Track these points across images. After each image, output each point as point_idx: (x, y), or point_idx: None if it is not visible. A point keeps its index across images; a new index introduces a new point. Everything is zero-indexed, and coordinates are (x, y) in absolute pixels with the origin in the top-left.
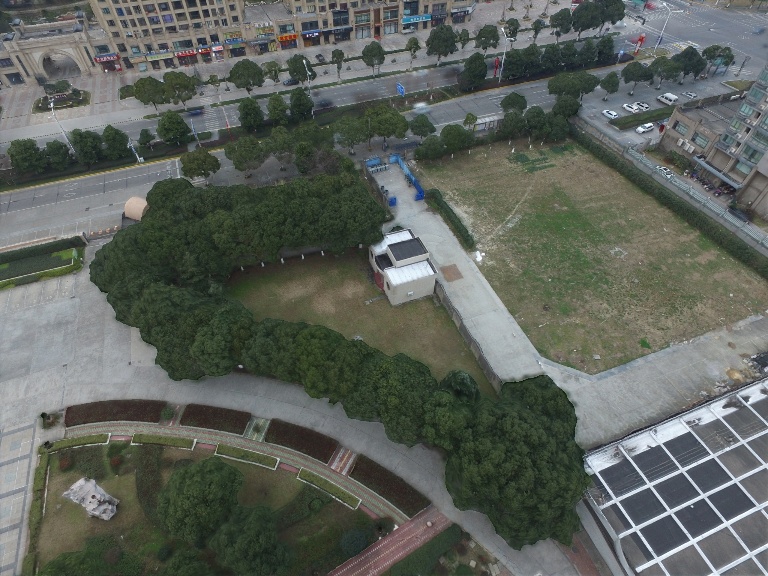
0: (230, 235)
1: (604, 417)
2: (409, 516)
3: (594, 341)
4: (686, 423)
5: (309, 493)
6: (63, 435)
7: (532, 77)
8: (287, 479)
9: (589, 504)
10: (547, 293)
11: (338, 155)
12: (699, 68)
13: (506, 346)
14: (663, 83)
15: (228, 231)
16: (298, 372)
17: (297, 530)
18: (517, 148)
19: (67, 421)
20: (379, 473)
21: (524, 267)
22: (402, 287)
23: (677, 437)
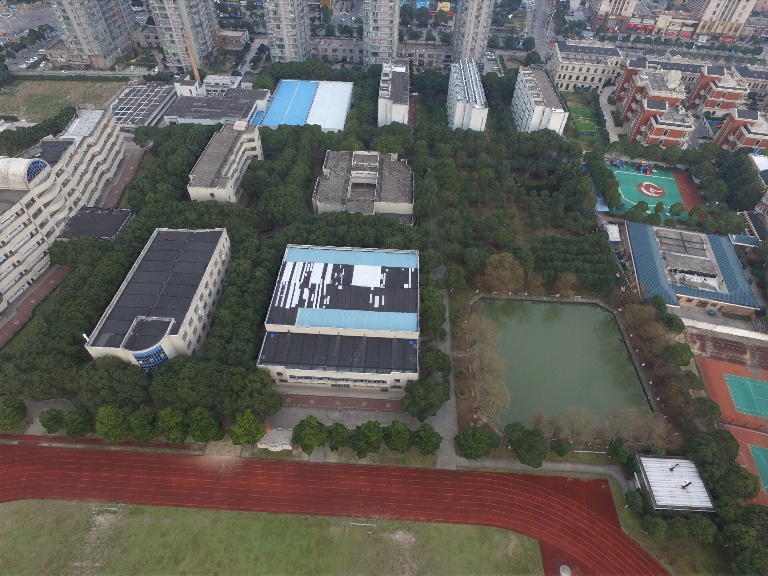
0: None
1: None
2: None
3: None
4: (112, 106)
5: None
6: None
7: None
8: None
9: None
10: None
11: None
12: (42, 36)
13: None
14: (35, 48)
15: None
16: None
17: None
18: None
19: None
20: None
21: (43, 114)
22: None
23: None
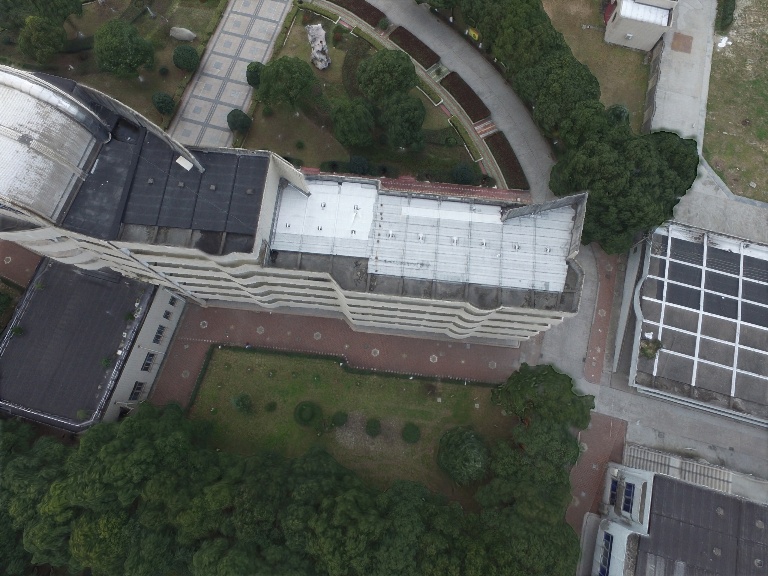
0: None
1: (712, 225)
2: (509, 186)
3: (764, 172)
4: None
5: (451, 132)
6: (311, 1)
7: None
8: (441, 116)
9: (645, 250)
10: (760, 111)
11: None
12: None
13: (678, 129)
14: None
15: None
16: (498, 30)
17: (430, 148)
18: None
19: None
20: (506, 149)
21: (760, 77)
22: (627, 23)
23: (761, 259)
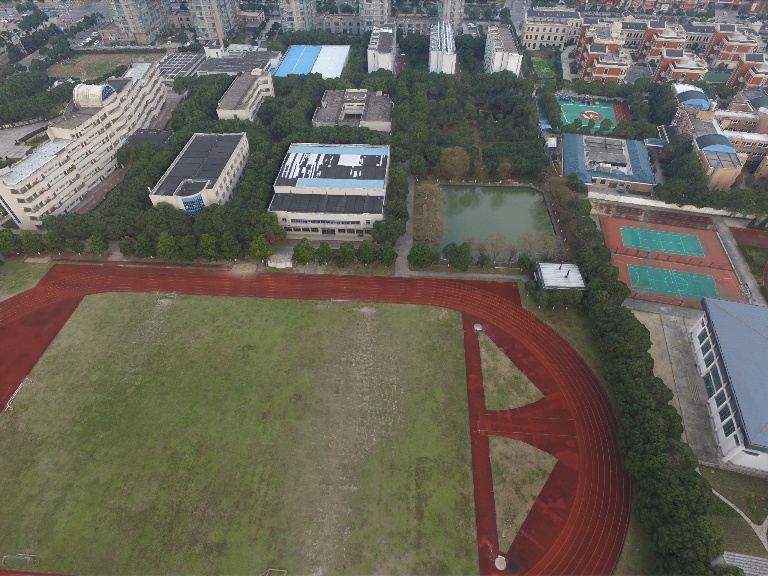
0: (11, 92)
1: None
2: None
3: None
4: None
5: None
6: None
7: (38, 47)
8: None
9: None
10: None
11: (6, 79)
12: (95, 21)
13: None
14: (88, 32)
15: (9, 91)
16: None
17: None
18: (62, 63)
19: (23, 140)
20: None
21: None
22: None
23: None
